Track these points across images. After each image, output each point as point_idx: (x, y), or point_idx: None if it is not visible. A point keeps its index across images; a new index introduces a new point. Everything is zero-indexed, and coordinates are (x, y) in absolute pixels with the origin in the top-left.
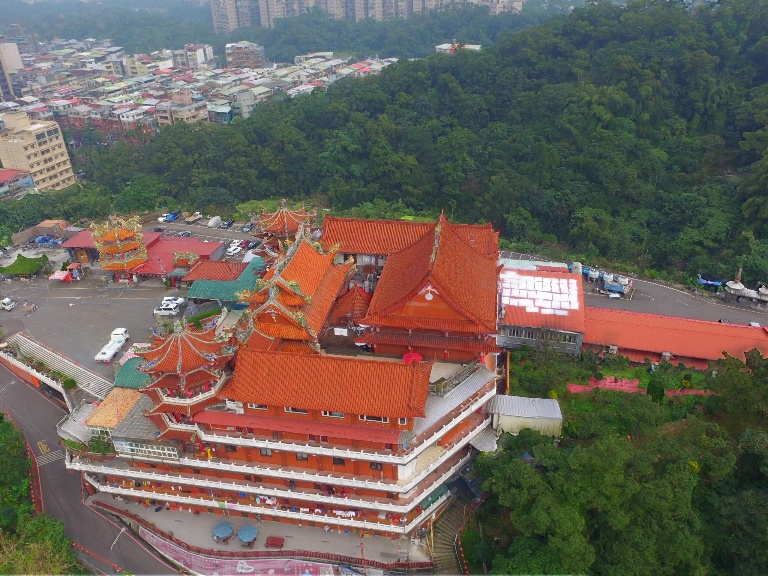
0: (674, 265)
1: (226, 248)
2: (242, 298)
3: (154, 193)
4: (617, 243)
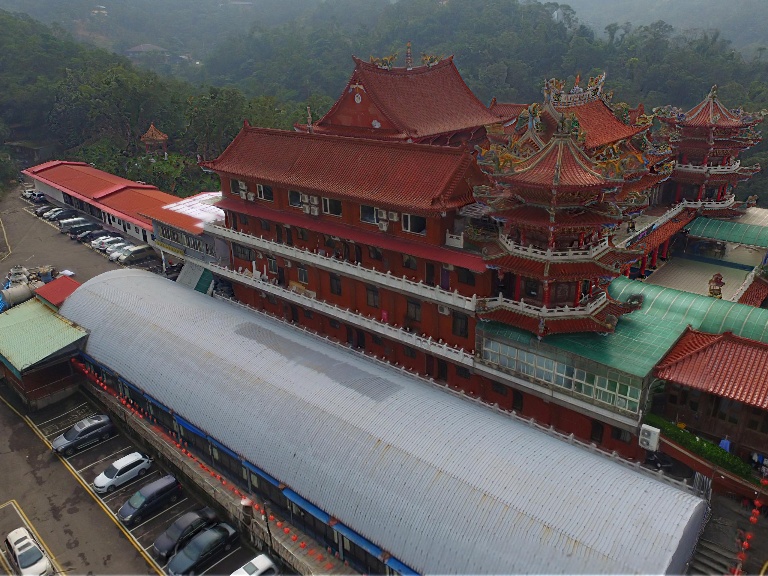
0: None
1: None
2: (648, 123)
3: None
4: None
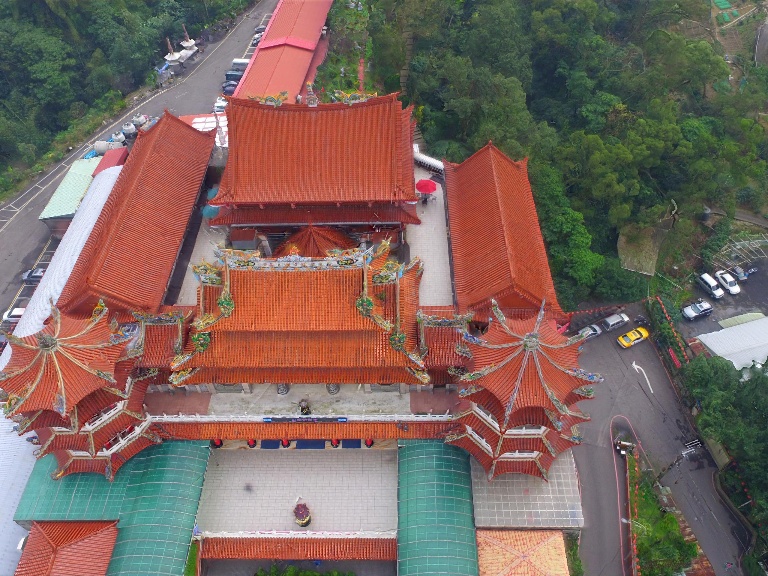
0: (57, 111)
1: None
2: None
3: None
4: (11, 132)
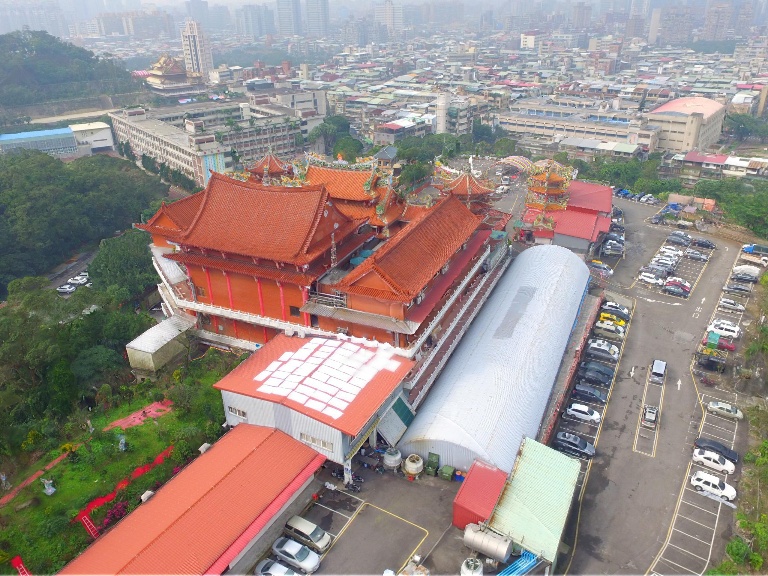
0: None
1: (665, 278)
2: None
3: (767, 216)
4: None
